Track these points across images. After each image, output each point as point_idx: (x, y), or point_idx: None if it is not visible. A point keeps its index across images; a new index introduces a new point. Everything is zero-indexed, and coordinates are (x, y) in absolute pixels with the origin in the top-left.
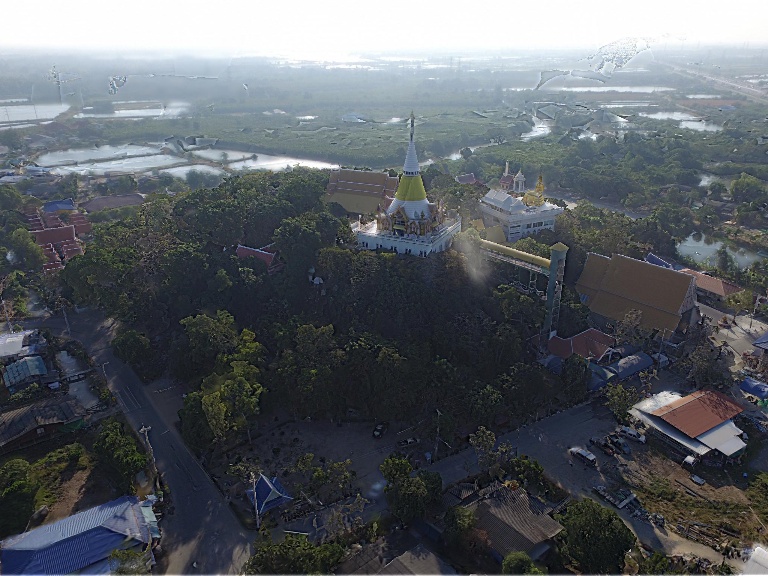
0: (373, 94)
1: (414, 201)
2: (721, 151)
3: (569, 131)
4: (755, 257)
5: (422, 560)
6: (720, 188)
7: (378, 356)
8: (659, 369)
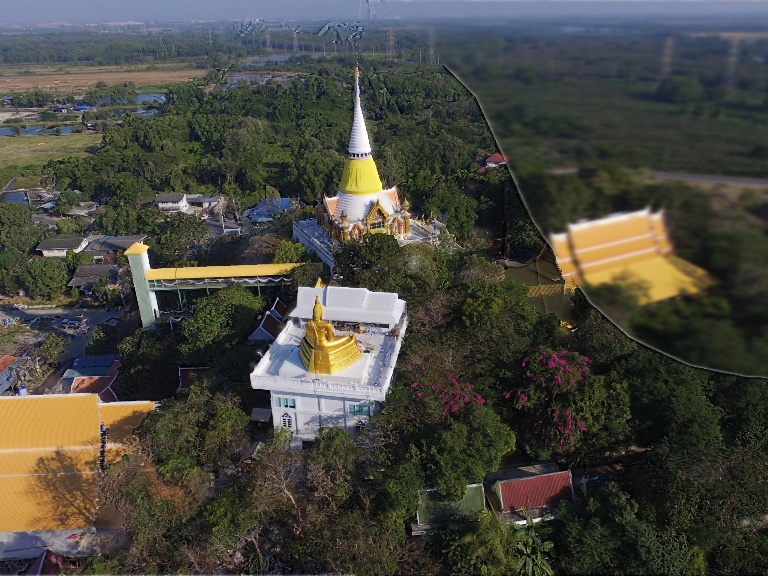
0: None
1: None
2: None
3: None
4: None
5: (130, 244)
6: None
7: None
8: None
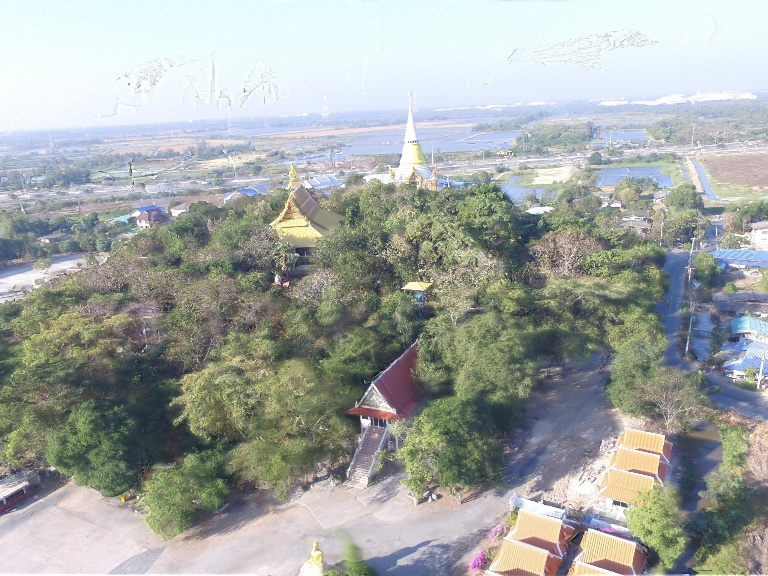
0: (7, 128)
1: None
2: None
3: None
4: None
5: None
6: None
7: None
8: None
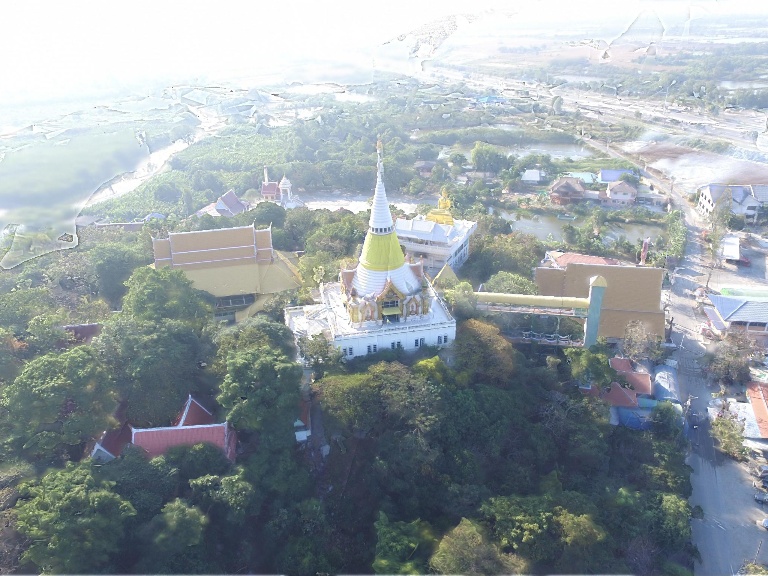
0: (116, 108)
1: (399, 268)
2: (407, 120)
3: (256, 118)
4: (554, 221)
5: None
6: (462, 159)
7: (558, 534)
8: (677, 376)
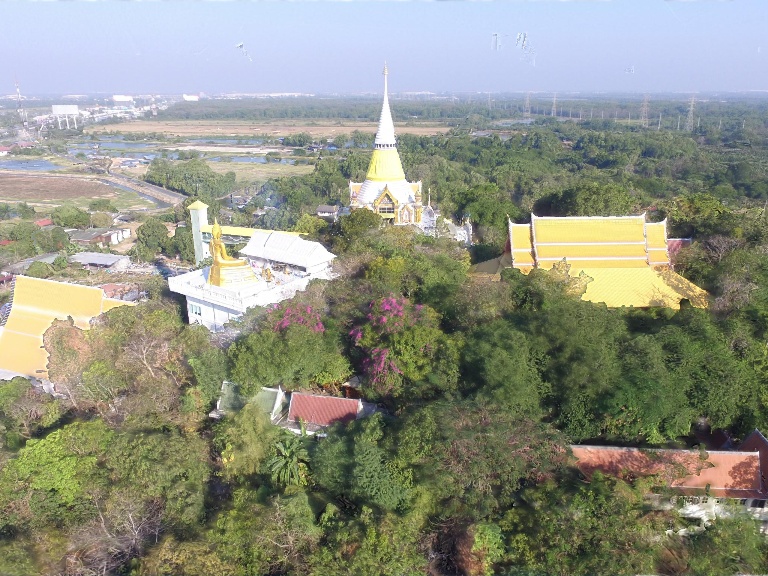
0: None
1: None
2: None
3: None
4: None
5: None
6: None
7: None
8: None
